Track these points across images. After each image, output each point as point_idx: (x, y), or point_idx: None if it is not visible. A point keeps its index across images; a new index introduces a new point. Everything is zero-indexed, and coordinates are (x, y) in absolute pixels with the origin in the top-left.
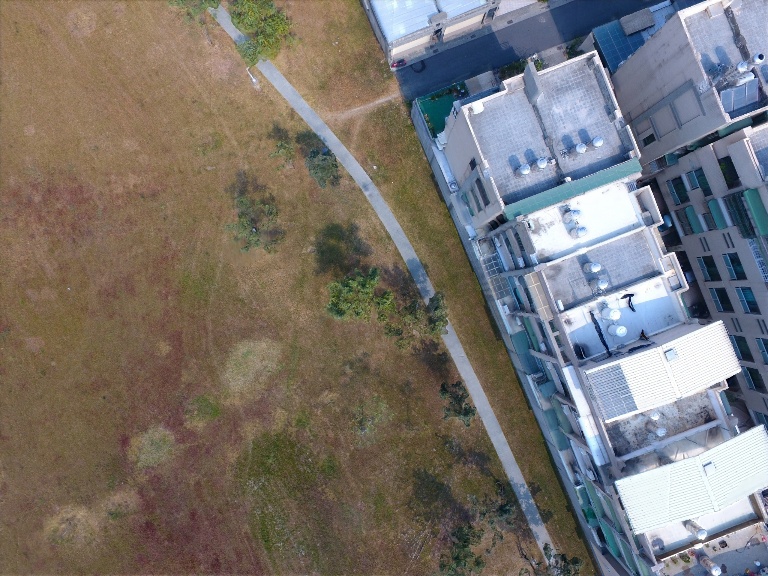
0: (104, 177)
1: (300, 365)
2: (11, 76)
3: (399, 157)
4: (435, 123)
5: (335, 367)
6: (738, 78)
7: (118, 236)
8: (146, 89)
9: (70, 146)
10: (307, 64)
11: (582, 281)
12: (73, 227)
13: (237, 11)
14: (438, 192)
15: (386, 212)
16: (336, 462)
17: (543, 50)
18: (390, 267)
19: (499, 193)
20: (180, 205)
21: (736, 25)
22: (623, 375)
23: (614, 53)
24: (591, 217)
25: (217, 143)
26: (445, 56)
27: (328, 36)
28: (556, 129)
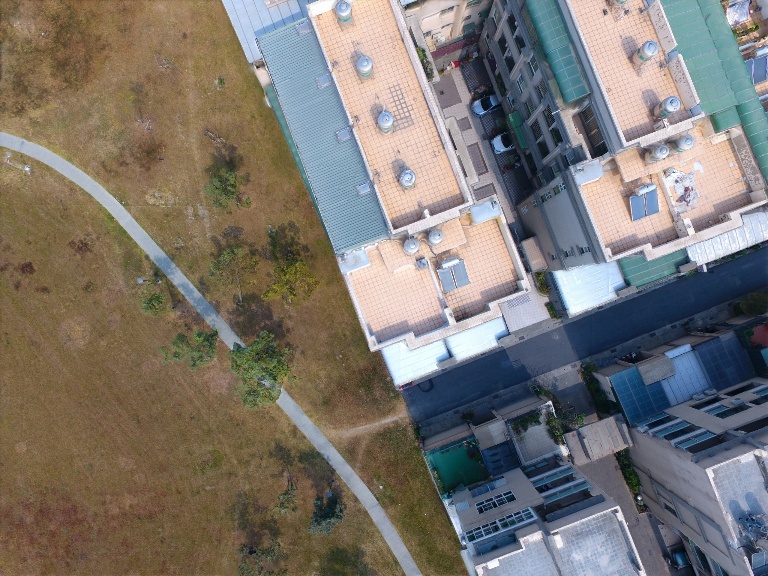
0: (99, 497)
1: None
2: (2, 390)
3: (406, 478)
4: (445, 473)
5: None
6: None
7: (114, 559)
8: (142, 405)
9: (63, 464)
10: (310, 378)
11: None
12: (67, 550)
13: (237, 362)
14: (447, 515)
15: (393, 535)
16: None
17: (556, 368)
18: None
19: None
20: (178, 527)
21: (767, 476)
22: None
23: (632, 403)
24: None
25: (216, 461)
26: (454, 374)
27: (332, 349)
28: None
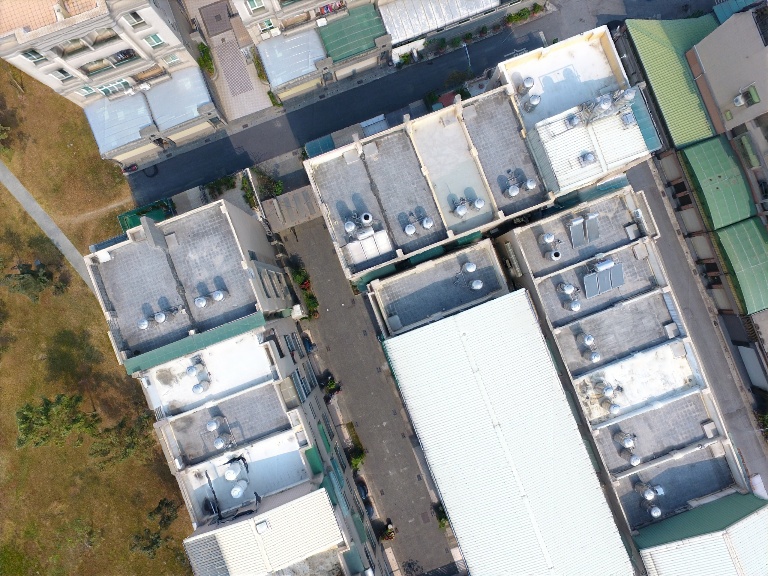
0: None
1: (29, 475)
2: None
3: None
4: None
5: (65, 477)
6: (357, 233)
7: None
8: None
9: None
10: (41, 166)
11: (213, 434)
12: None
13: None
14: None
15: None
16: (65, 575)
17: (278, 155)
18: (122, 375)
19: (132, 342)
20: None
21: (368, 174)
22: (218, 546)
23: None
24: (224, 368)
25: None
26: (178, 161)
27: (63, 138)
28: (191, 276)
